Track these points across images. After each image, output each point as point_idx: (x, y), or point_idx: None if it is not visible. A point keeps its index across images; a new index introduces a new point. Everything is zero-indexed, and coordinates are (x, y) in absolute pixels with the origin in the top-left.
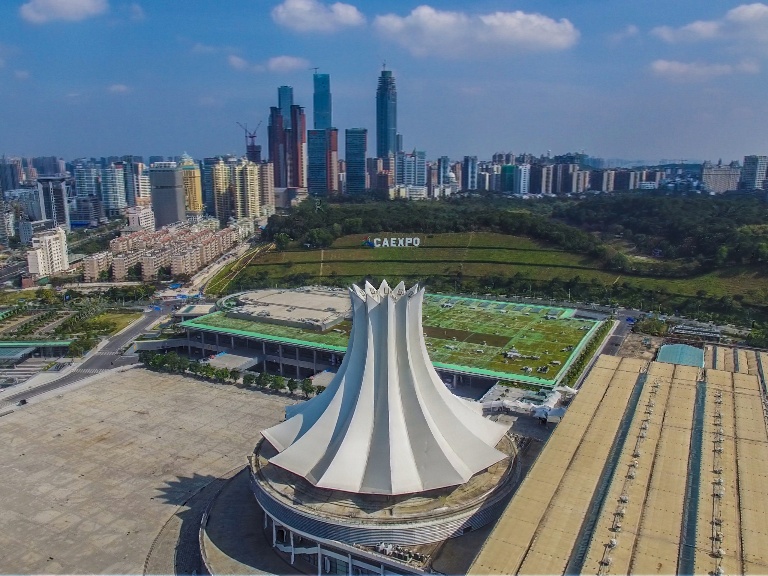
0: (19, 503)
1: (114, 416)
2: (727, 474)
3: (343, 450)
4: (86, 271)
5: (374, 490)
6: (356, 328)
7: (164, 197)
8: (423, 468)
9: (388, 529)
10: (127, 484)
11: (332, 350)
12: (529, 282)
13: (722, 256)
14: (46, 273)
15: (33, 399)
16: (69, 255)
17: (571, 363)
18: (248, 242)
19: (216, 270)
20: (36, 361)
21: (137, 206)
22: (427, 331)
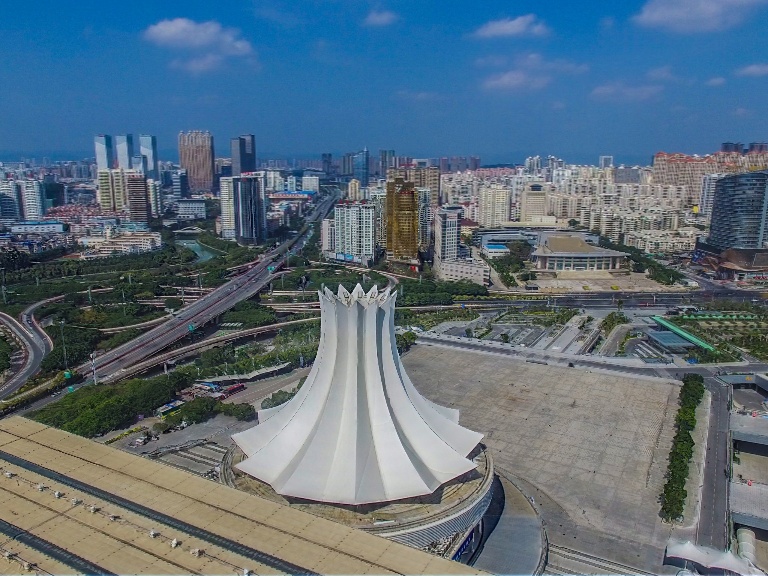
0: None
1: (559, 396)
2: None
3: None
4: None
5: None
6: None
7: None
8: None
9: None
10: None
11: None
12: None
13: None
14: None
15: (585, 368)
16: None
17: None
18: None
19: None
20: None
21: None
22: None
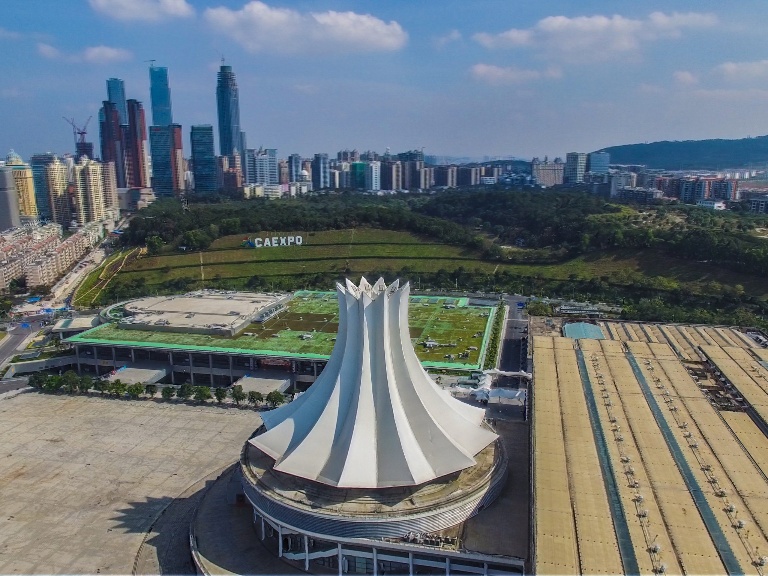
0: None
1: (22, 448)
2: (691, 428)
3: (353, 448)
4: None
5: (394, 483)
6: (349, 326)
7: None
8: (431, 456)
9: (415, 518)
10: (72, 519)
11: (252, 354)
12: (416, 275)
13: (585, 243)
14: None
15: None
16: None
17: (486, 347)
18: (101, 248)
19: (76, 279)
20: None
21: None
22: None
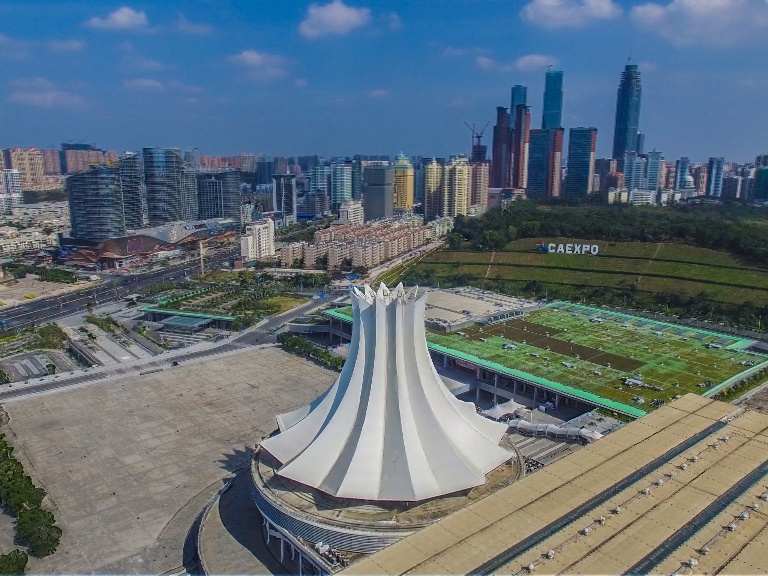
0: (121, 444)
1: (231, 386)
2: (713, 557)
3: (316, 445)
4: (283, 258)
5: (327, 488)
6: (354, 328)
7: (374, 194)
8: (386, 477)
9: (327, 529)
10: (204, 445)
11: (442, 352)
12: (714, 304)
13: None
14: (254, 257)
15: (185, 362)
16: (276, 243)
17: None
18: (443, 240)
19: None
20: (211, 331)
21: (348, 201)
22: (553, 345)
